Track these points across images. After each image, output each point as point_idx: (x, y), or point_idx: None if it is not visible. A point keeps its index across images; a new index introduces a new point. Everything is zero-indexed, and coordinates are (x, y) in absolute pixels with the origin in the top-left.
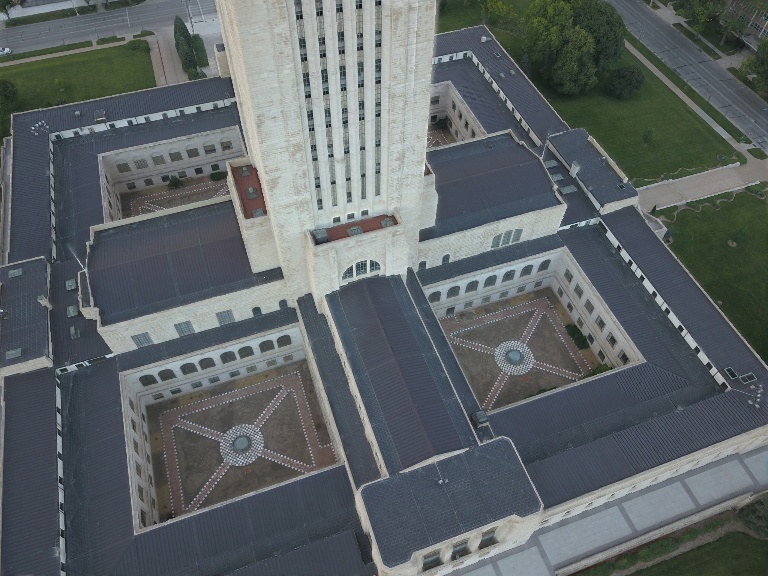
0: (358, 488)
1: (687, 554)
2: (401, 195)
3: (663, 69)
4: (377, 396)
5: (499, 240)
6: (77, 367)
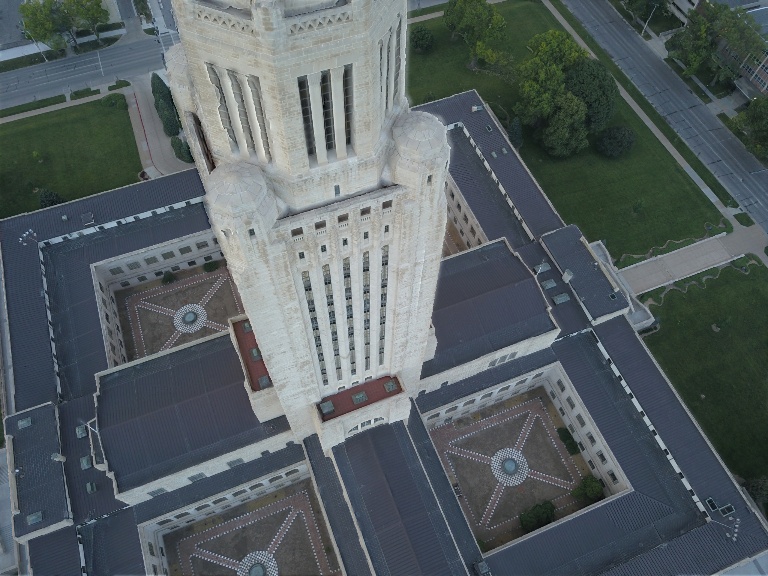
0: None
1: None
2: (403, 363)
3: (654, 117)
4: (387, 561)
5: (495, 361)
6: (96, 519)
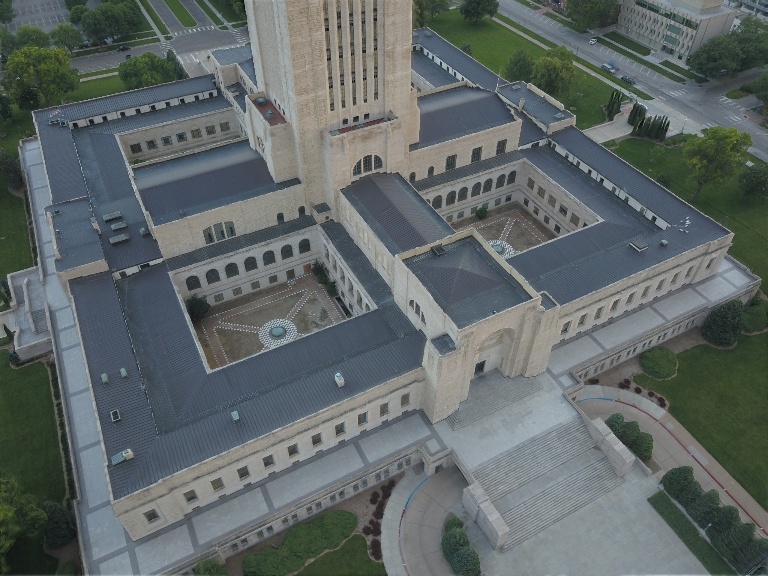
0: None
1: None
2: None
3: None
4: None
5: None
6: None
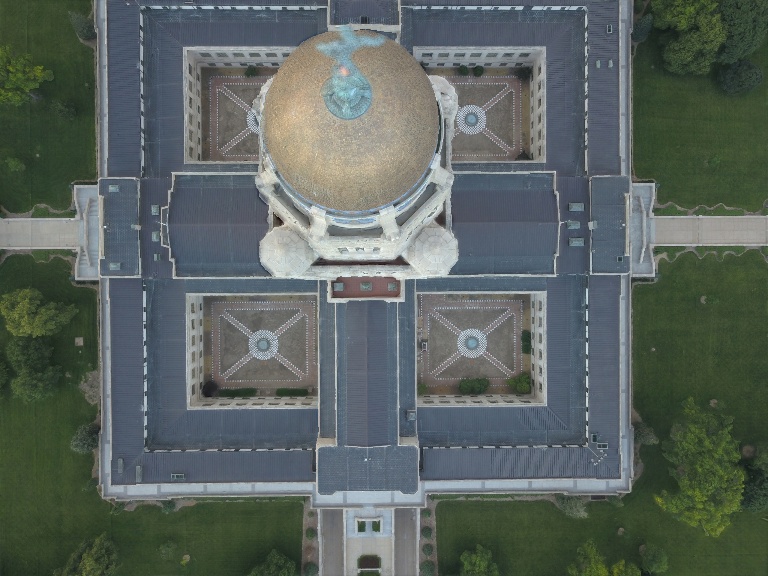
0: (321, 432)
1: (511, 502)
2: None
3: None
4: (347, 393)
5: None
6: None
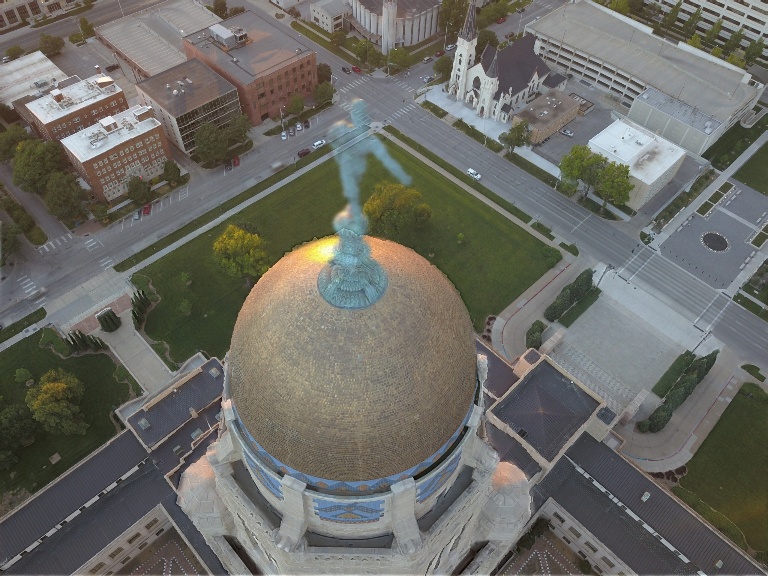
0: None
1: None
2: None
3: None
4: None
5: None
6: None
